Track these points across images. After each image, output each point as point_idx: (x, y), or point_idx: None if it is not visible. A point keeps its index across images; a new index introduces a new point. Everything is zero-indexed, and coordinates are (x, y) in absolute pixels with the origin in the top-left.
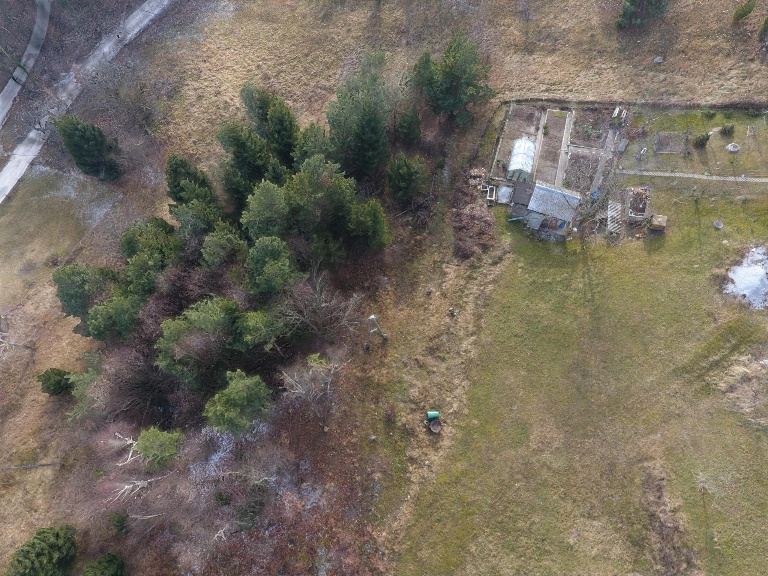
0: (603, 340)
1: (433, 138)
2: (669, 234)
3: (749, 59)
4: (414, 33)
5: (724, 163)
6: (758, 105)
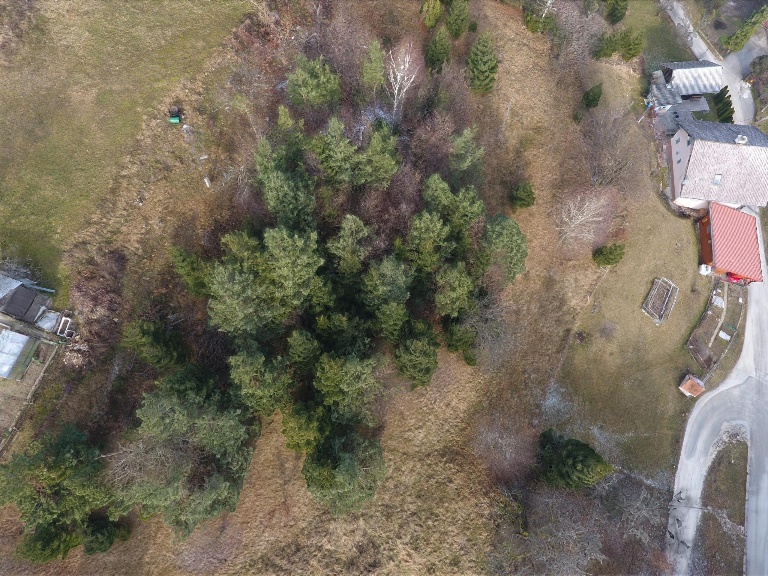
0: (1, 156)
1: None
2: None
3: None
4: None
5: None
6: None
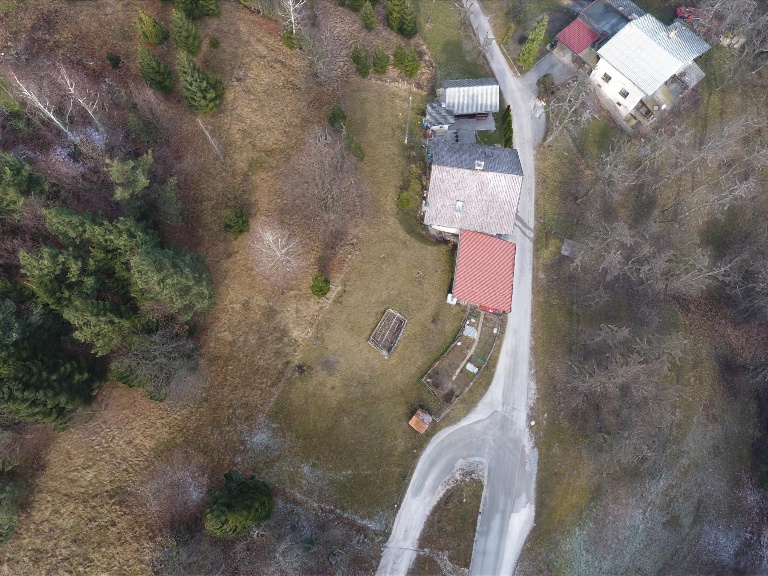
0: None
1: None
2: None
3: None
4: None
5: None
6: None
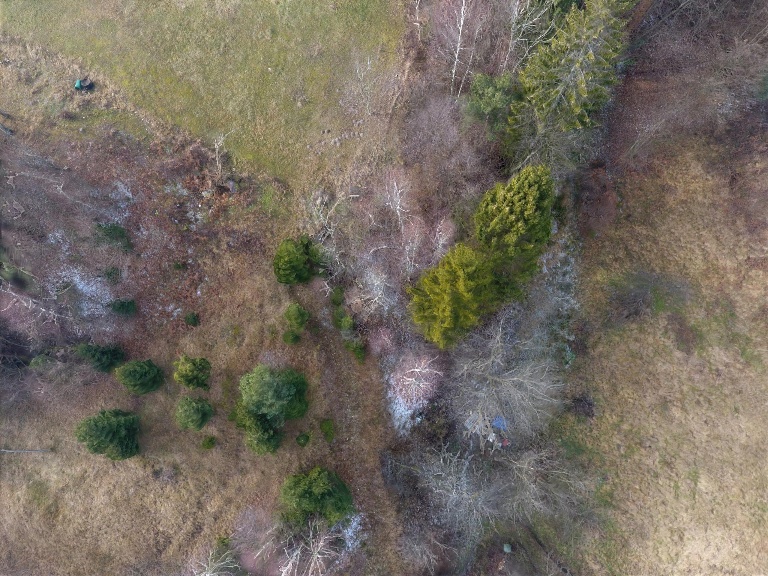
0: None
1: None
2: None
3: None
4: None
5: None
6: None
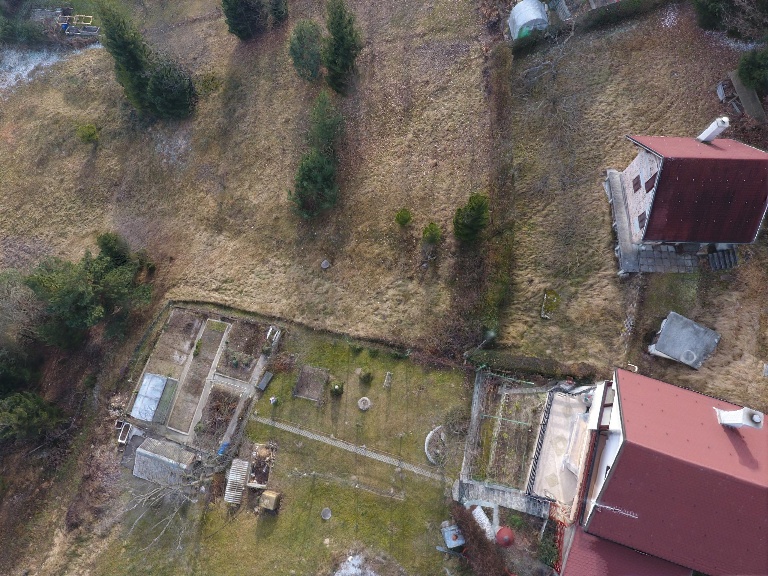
0: None
1: (102, 339)
2: (281, 516)
3: (408, 277)
4: (125, 188)
5: (351, 424)
6: (400, 346)
